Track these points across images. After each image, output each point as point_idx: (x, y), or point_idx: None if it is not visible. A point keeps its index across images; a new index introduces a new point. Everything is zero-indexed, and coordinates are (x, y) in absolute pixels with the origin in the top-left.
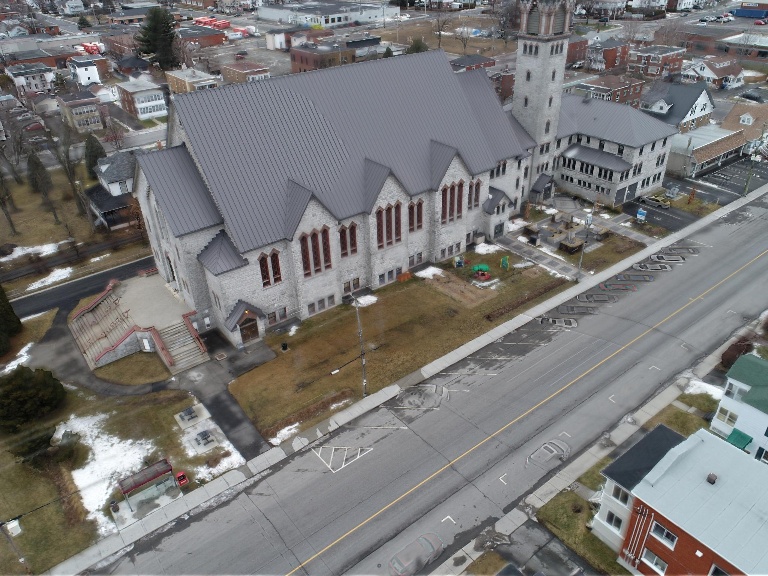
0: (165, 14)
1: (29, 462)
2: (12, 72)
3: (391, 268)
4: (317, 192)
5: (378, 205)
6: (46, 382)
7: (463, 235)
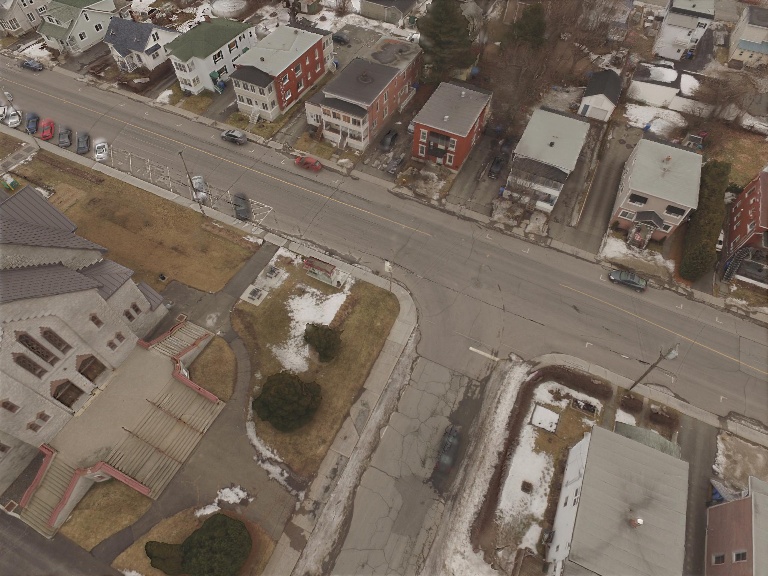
0: None
1: None
2: None
3: None
4: None
5: None
6: None
7: None
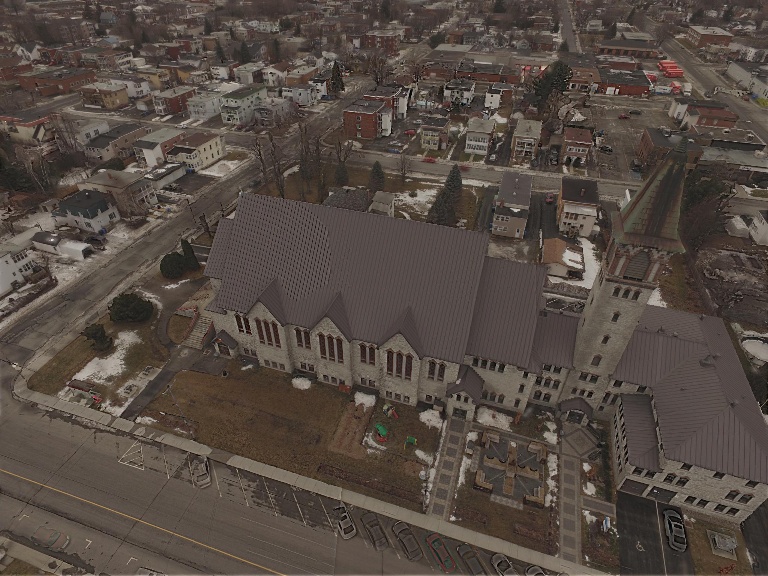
0: (565, 68)
1: (95, 340)
2: (447, 85)
3: (334, 376)
4: (286, 296)
5: (320, 331)
6: (136, 308)
7: (413, 394)
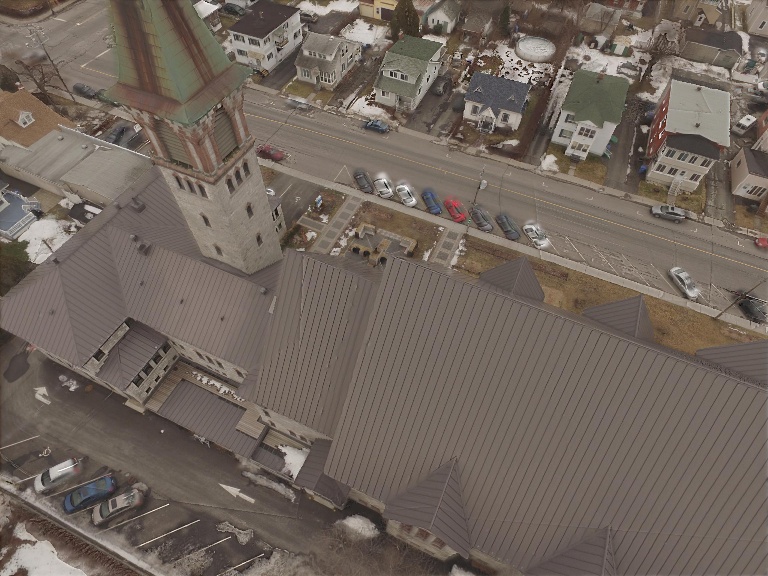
0: None
1: None
2: None
3: None
4: None
5: None
6: None
7: None
